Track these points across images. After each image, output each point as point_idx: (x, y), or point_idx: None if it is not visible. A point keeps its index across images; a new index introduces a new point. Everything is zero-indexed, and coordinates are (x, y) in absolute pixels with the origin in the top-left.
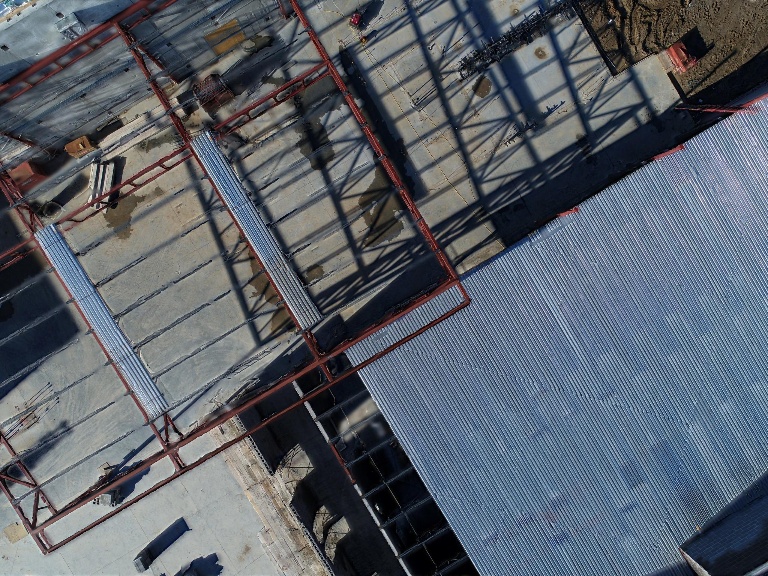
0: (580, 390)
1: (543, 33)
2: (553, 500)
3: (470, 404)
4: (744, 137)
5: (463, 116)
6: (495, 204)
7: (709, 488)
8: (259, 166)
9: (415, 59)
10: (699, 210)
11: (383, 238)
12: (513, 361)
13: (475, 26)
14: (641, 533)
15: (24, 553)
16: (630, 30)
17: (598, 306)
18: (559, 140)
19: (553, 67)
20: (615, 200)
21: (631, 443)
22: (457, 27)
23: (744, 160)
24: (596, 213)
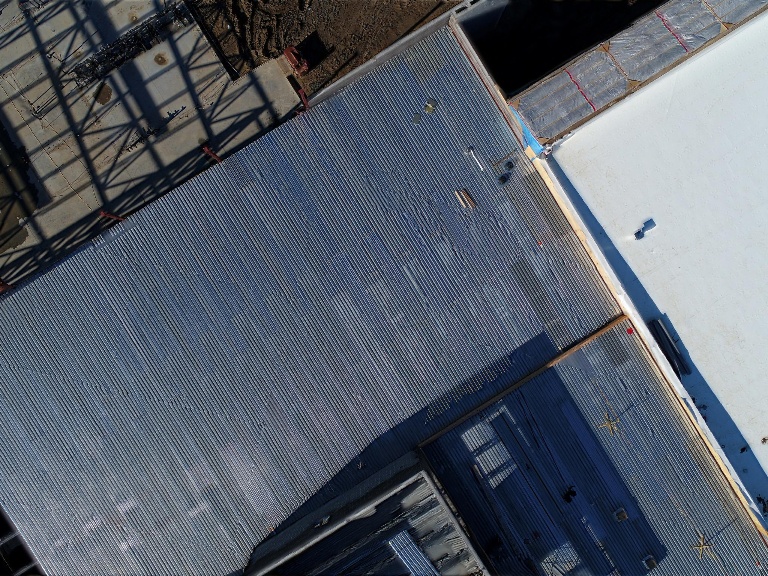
0: (148, 393)
1: (161, 40)
2: (124, 504)
3: (36, 409)
4: (308, 139)
5: (84, 123)
6: (119, 210)
7: (283, 489)
8: None
9: (35, 67)
10: (265, 212)
11: (8, 245)
12: (79, 366)
13: (94, 34)
14: (215, 535)
15: None
16: (251, 35)
17: (165, 309)
18: (181, 145)
19: (173, 73)
20: (179, 203)
21: (202, 445)
22: (76, 35)
23: (308, 161)
24: (160, 217)
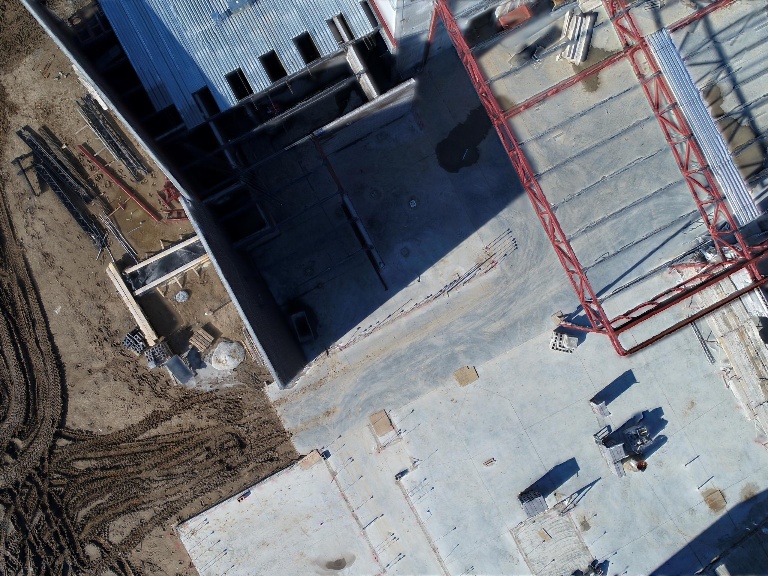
0: None
1: None
2: None
3: None
4: None
5: None
6: None
7: None
8: (726, 28)
9: None
10: None
11: None
12: None
13: None
14: None
15: (473, 397)
16: None
17: None
18: None
19: None
20: None
21: None
22: None
23: None
24: None
